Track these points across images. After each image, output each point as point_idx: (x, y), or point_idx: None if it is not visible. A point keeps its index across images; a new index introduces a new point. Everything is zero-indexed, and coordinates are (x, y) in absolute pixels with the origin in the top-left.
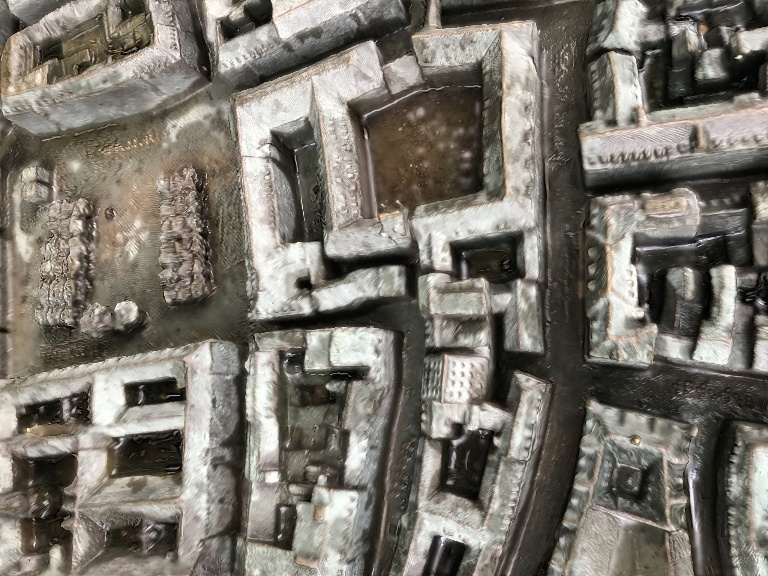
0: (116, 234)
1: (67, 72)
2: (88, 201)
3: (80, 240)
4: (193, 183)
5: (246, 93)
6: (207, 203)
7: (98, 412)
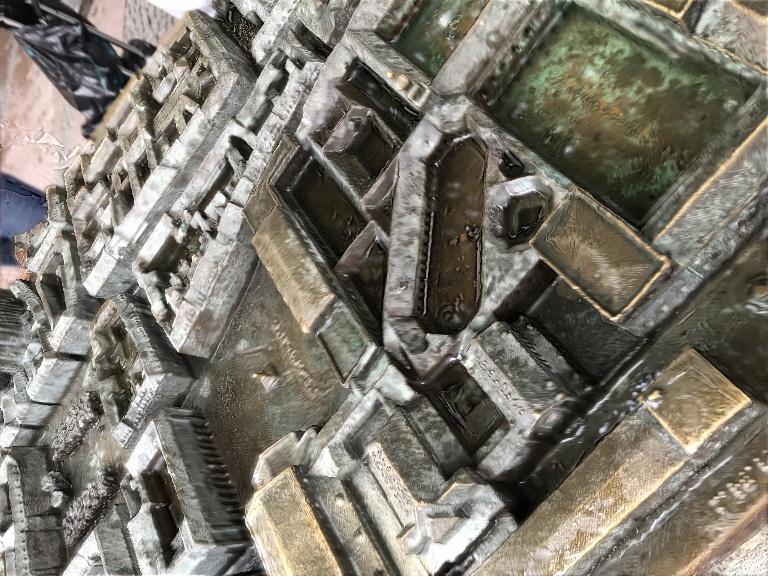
0: (97, 442)
1: (116, 353)
2: (95, 416)
3: (80, 430)
4: (102, 495)
5: (101, 530)
6: (111, 501)
7: (5, 538)
